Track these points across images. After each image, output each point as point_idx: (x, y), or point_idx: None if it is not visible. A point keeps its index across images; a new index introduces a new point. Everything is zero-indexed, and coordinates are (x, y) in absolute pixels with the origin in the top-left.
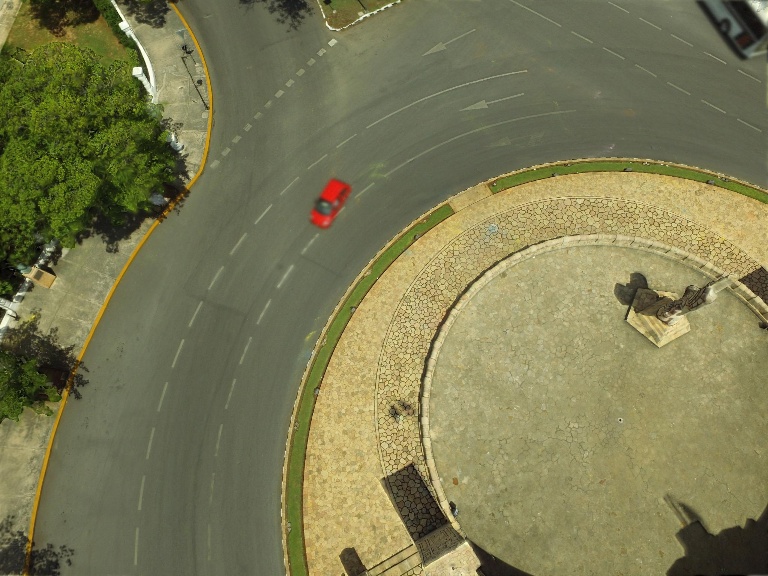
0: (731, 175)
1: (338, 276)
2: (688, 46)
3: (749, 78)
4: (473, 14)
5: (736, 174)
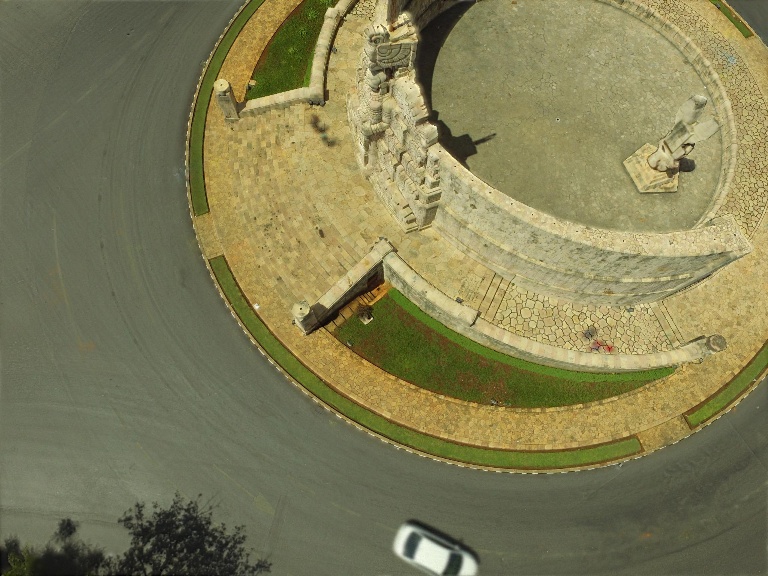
0: None
1: None
2: None
3: None
4: None
5: None
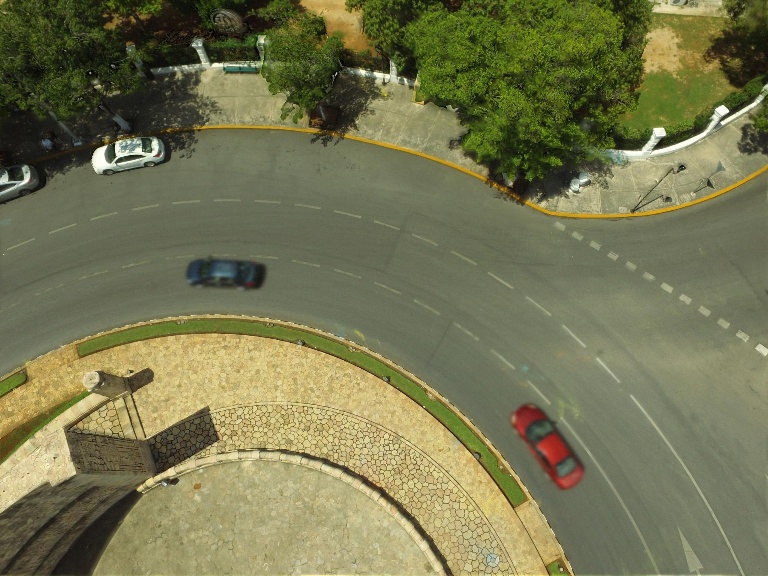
0: None
1: (427, 363)
2: None
3: None
4: None
5: None
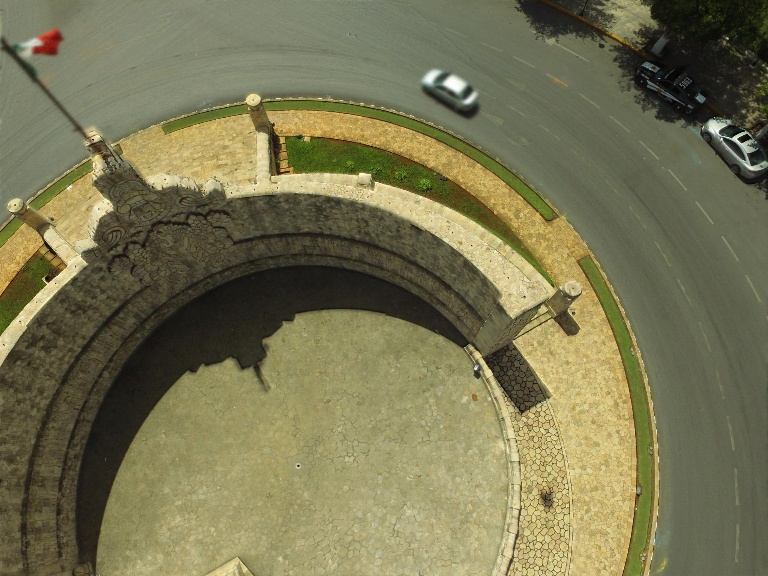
0: None
1: None
2: None
3: None
4: None
5: None
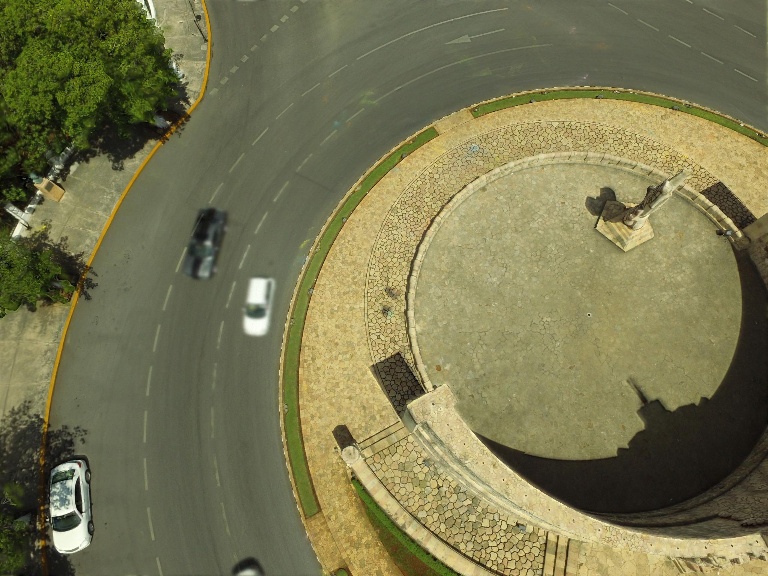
0: (694, 102)
1: (330, 191)
2: None
3: (713, 16)
4: None
5: (699, 101)
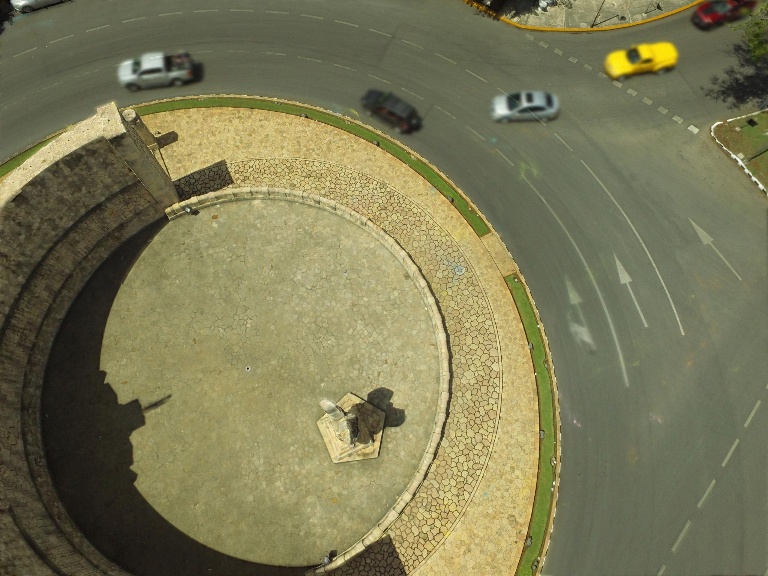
0: None
1: (411, 134)
2: (764, 569)
3: None
4: (767, 280)
5: None
